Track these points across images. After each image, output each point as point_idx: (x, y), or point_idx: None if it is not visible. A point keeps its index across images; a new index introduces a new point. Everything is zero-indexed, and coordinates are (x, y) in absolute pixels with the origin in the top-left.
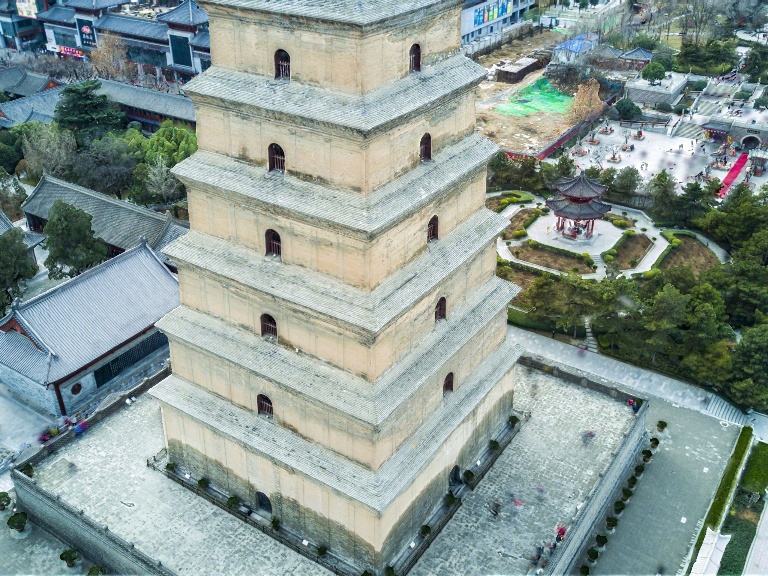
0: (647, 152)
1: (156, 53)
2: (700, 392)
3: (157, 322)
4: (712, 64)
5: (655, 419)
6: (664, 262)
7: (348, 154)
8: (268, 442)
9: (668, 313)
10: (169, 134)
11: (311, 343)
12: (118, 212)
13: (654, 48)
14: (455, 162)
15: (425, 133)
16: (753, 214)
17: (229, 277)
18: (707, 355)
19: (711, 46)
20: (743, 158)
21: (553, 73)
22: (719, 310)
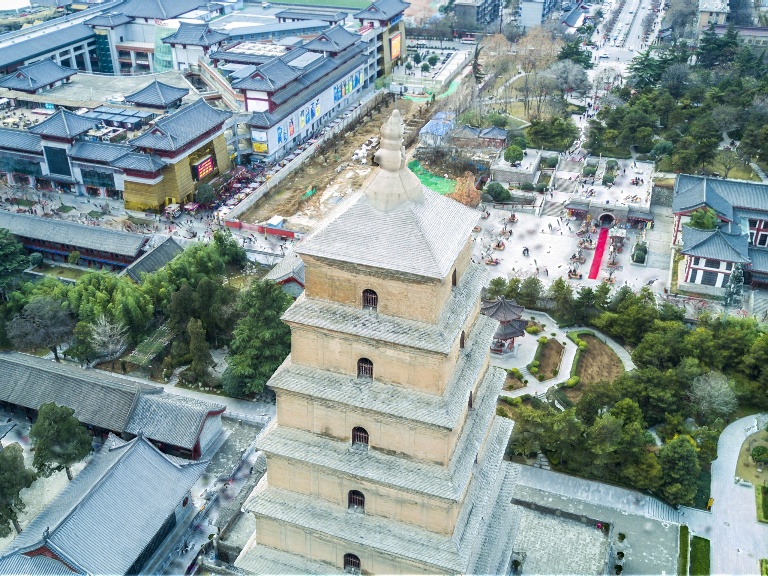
0: (524, 235)
1: (28, 163)
2: (640, 497)
3: (236, 562)
4: (559, 140)
5: (613, 530)
6: (578, 367)
7: (432, 439)
8: None
9: (609, 437)
10: (96, 282)
11: (396, 575)
12: (79, 386)
13: (506, 125)
14: (486, 402)
15: (470, 393)
16: (640, 316)
17: (318, 530)
18: (642, 466)
19: (556, 125)
20: (603, 234)
21: (422, 155)
22: (640, 420)
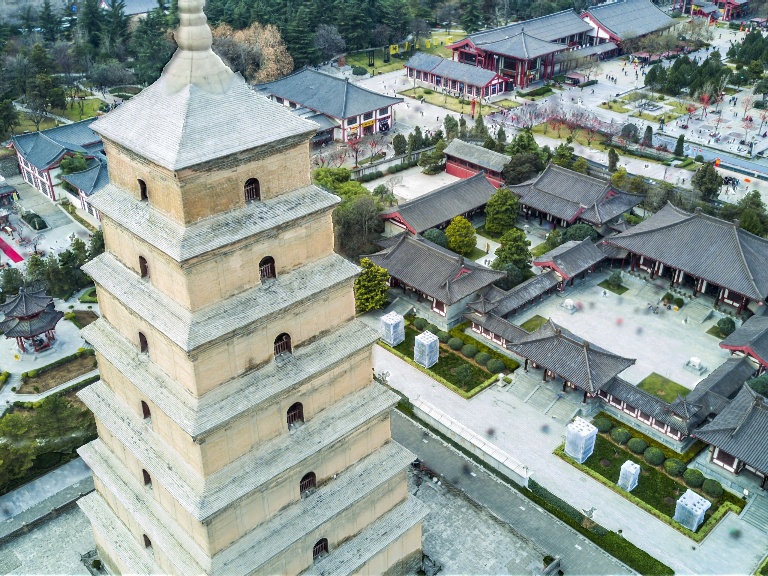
0: None
1: None
2: None
3: None
4: None
5: None
6: None
7: (342, 299)
8: (341, 568)
9: None
10: None
11: None
12: None
13: None
14: None
15: None
16: None
17: None
18: None
19: None
20: None
21: None
22: None
